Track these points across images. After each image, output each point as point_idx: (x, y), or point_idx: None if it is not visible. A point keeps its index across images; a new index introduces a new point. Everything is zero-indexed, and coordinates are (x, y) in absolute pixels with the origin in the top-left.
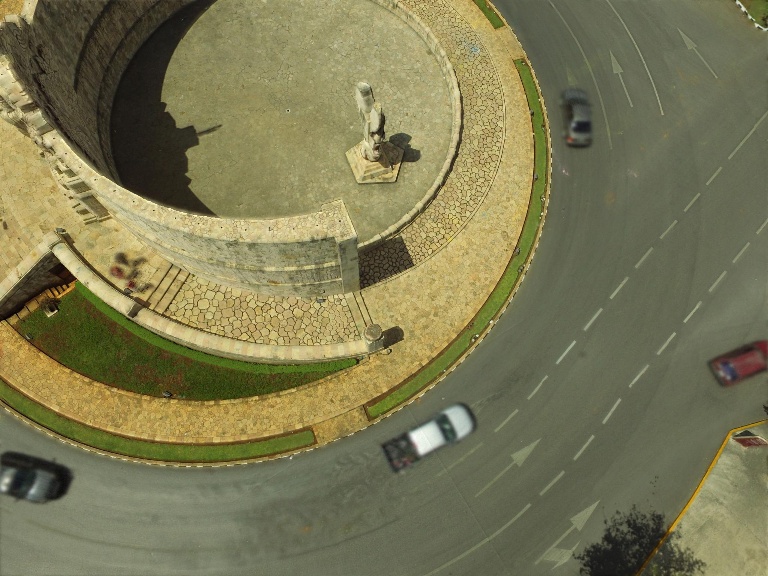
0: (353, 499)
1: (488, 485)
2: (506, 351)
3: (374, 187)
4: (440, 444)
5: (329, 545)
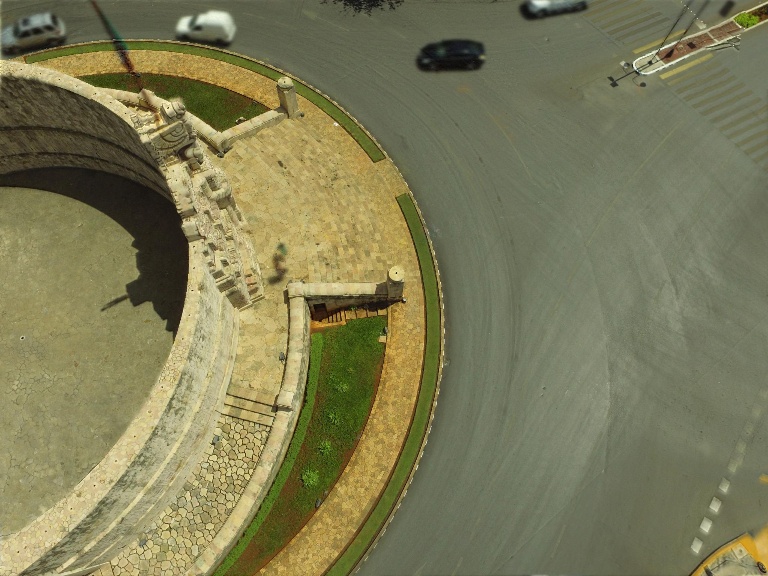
0: (2, 31)
1: None
2: None
3: None
4: None
5: (23, 8)
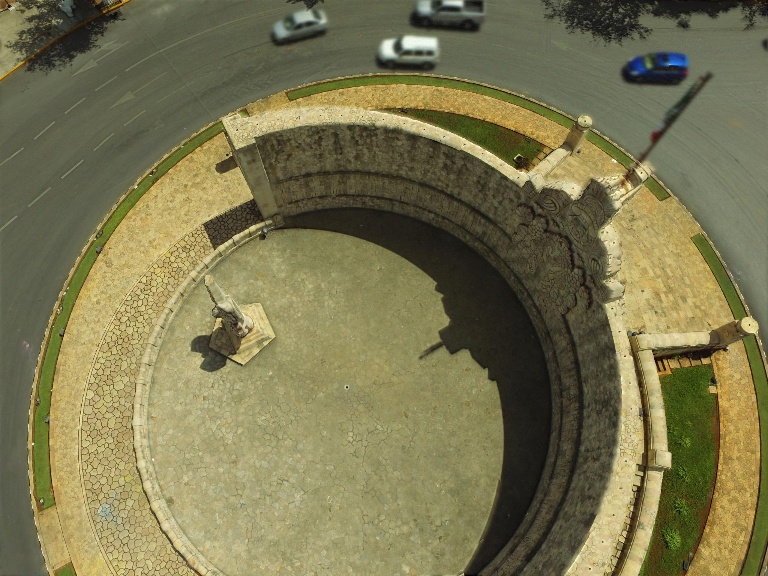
0: (257, 65)
1: (156, 79)
2: (127, 166)
3: (243, 302)
4: (190, 100)
5: (273, 42)
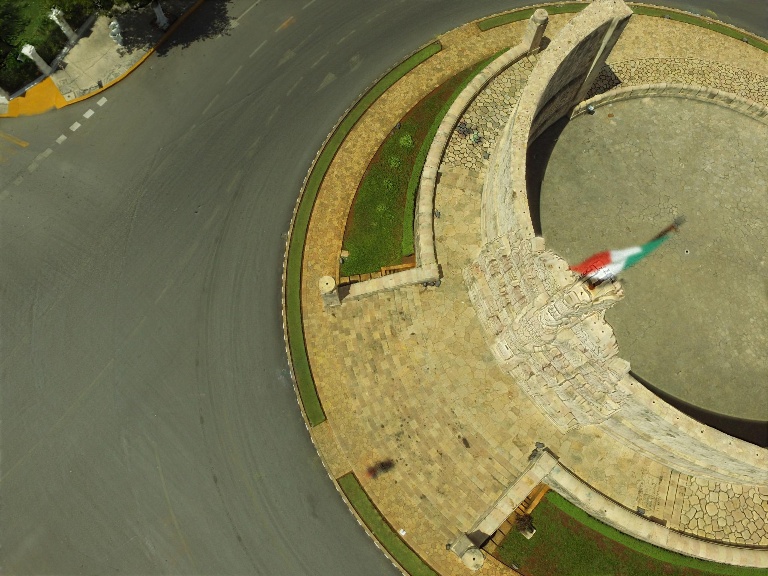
0: None
1: None
2: None
3: None
4: None
5: None
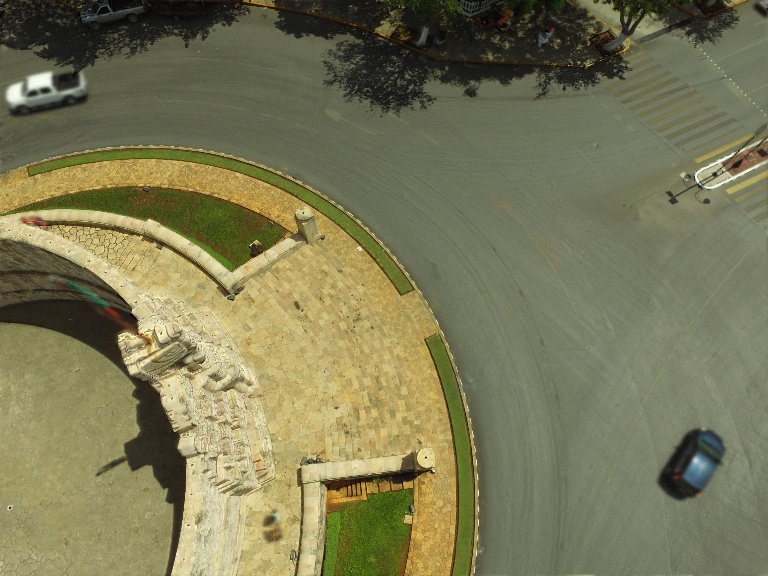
0: (6, 136)
1: None
2: None
3: None
4: None
5: (29, 109)
